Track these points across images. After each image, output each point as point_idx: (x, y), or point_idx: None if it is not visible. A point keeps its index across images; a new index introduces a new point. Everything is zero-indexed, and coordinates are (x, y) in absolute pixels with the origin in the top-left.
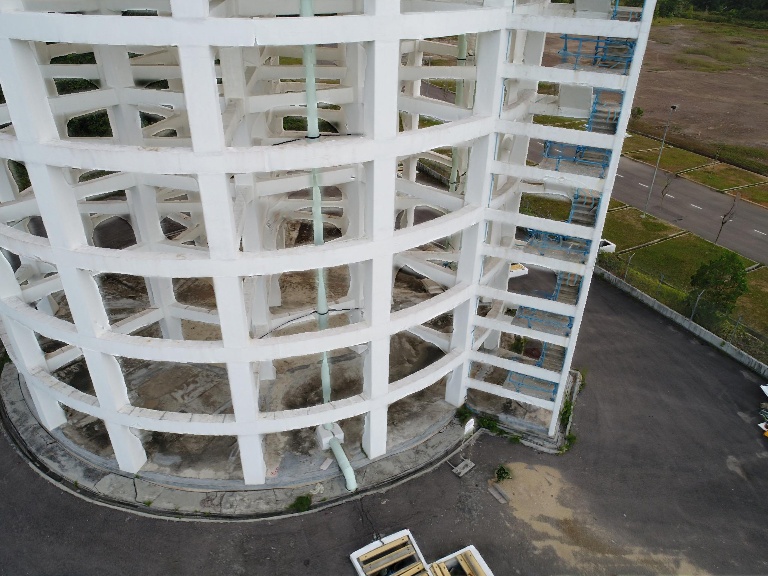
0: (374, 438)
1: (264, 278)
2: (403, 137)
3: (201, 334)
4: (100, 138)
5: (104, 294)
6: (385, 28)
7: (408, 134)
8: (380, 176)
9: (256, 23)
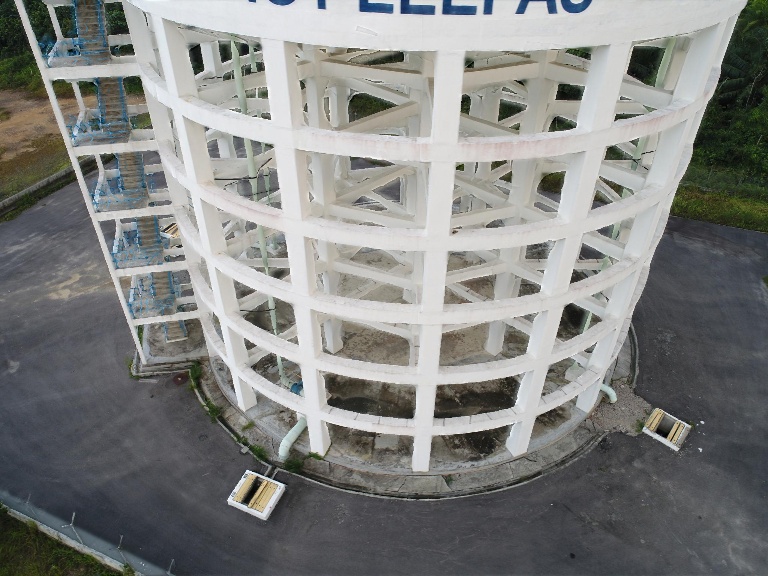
0: None
1: None
2: None
3: None
4: (498, 123)
5: None
6: None
7: None
8: None
9: None
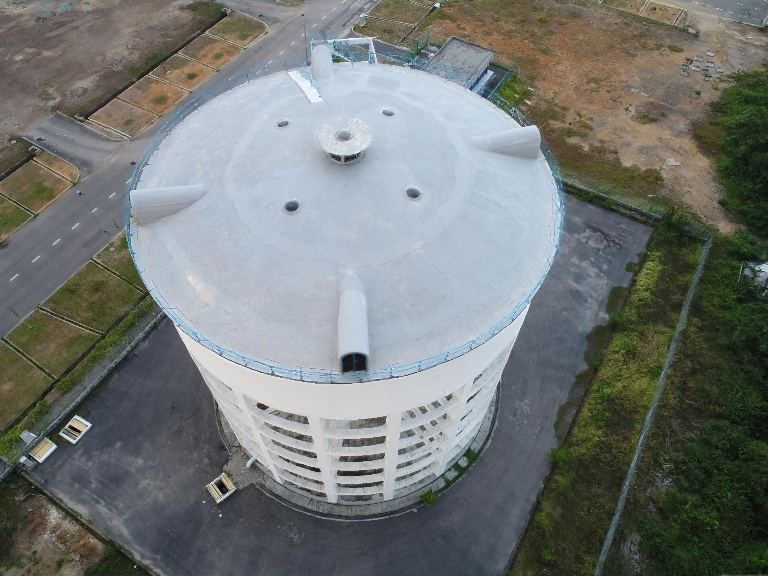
0: None
1: None
2: None
3: None
4: None
5: None
6: None
7: None
8: None
9: None
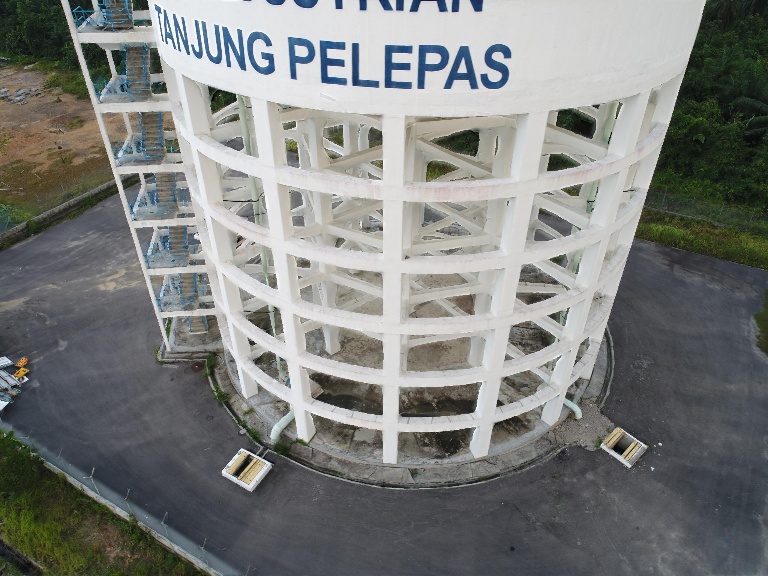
0: None
1: None
2: None
3: None
4: None
5: (523, 274)
6: None
7: None
8: None
9: None
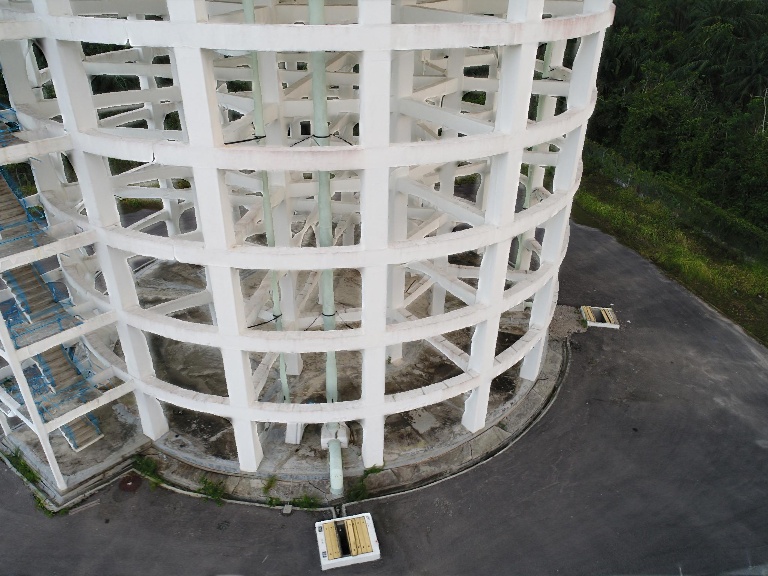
0: None
1: None
2: None
3: None
4: None
5: None
6: None
7: None
8: None
9: None
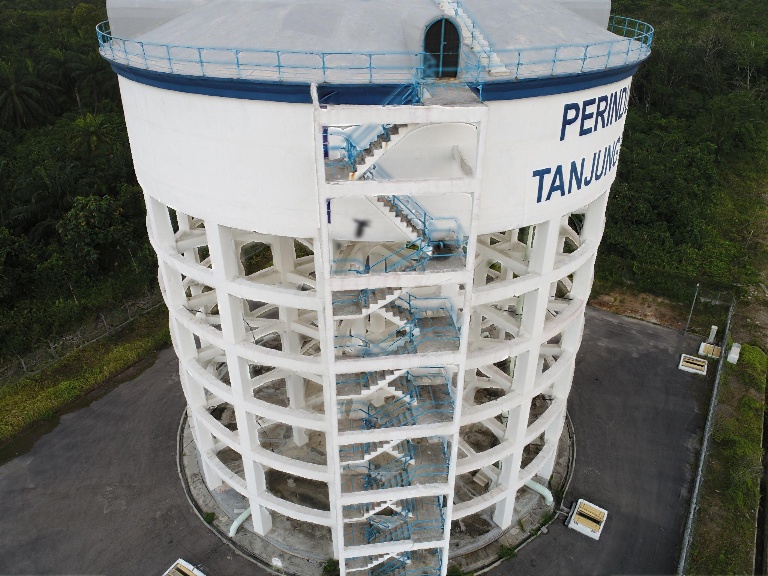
0: (254, 519)
1: (295, 380)
2: (240, 347)
3: (319, 391)
4: None
5: None
6: (219, 284)
7: (244, 346)
8: (230, 361)
9: (171, 258)
